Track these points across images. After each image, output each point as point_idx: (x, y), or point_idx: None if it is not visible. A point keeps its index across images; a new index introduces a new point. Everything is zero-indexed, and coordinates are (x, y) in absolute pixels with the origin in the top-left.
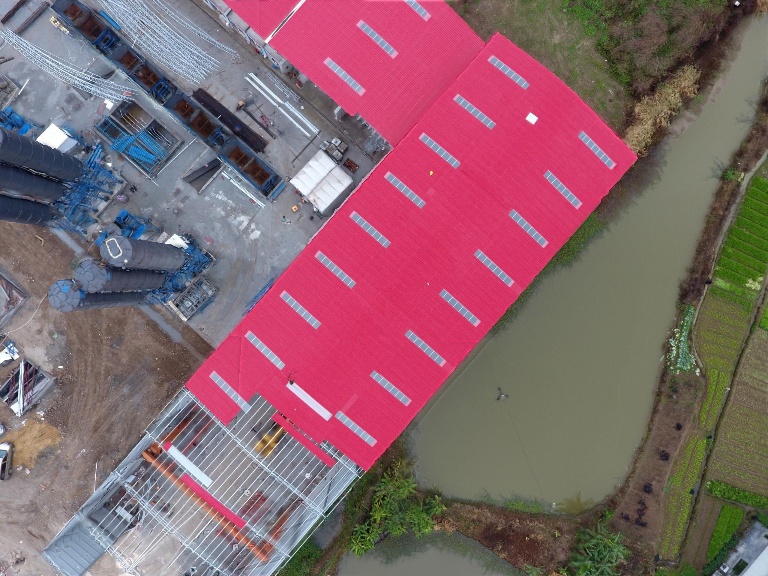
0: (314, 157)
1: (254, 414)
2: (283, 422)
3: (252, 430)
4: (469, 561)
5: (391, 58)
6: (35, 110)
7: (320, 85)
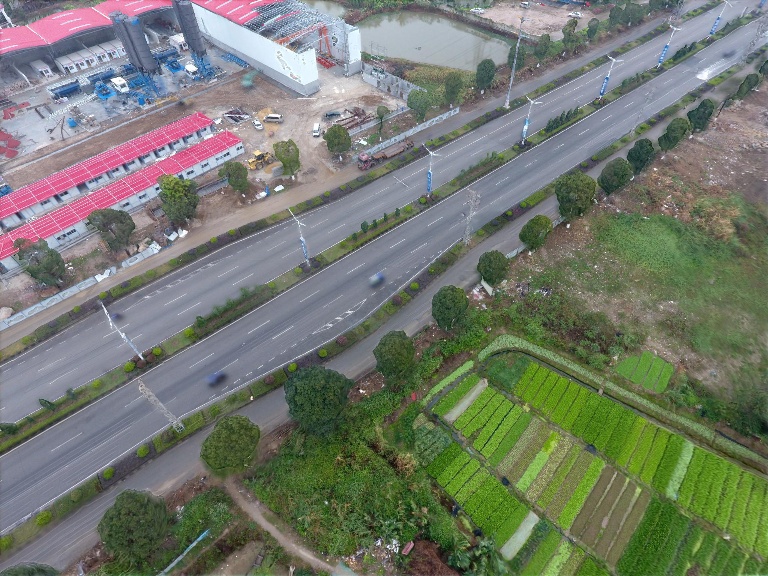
0: (171, 38)
1: (258, 9)
2: (263, 4)
3: (263, 9)
4: (359, 27)
5: (143, 1)
6: (96, 111)
7: (143, 11)
